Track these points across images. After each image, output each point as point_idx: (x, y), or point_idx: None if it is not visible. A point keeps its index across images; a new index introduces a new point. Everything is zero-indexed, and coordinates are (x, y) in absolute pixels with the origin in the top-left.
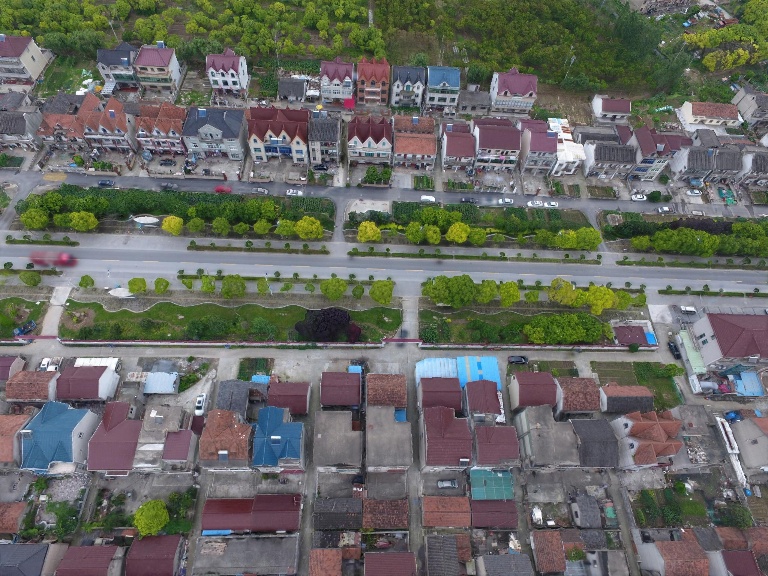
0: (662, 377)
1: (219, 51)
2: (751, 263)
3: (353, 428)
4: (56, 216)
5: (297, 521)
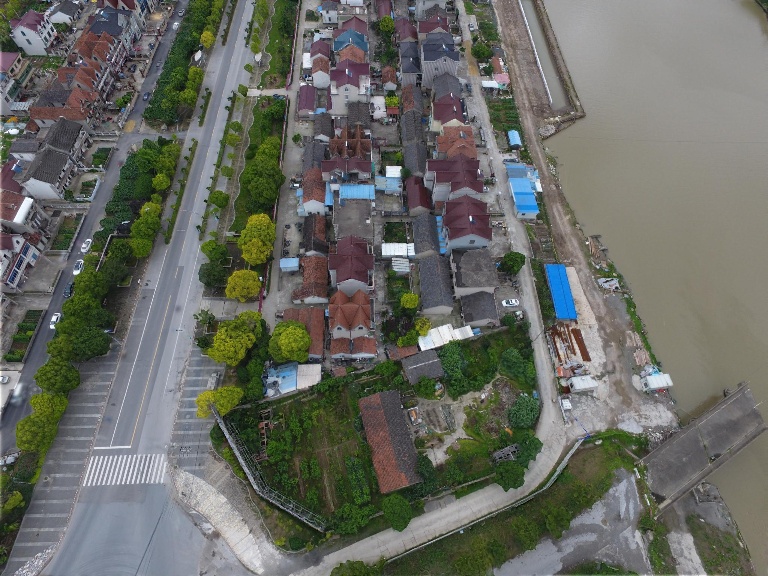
0: None
1: (3, 34)
2: None
3: None
4: (189, 84)
5: None
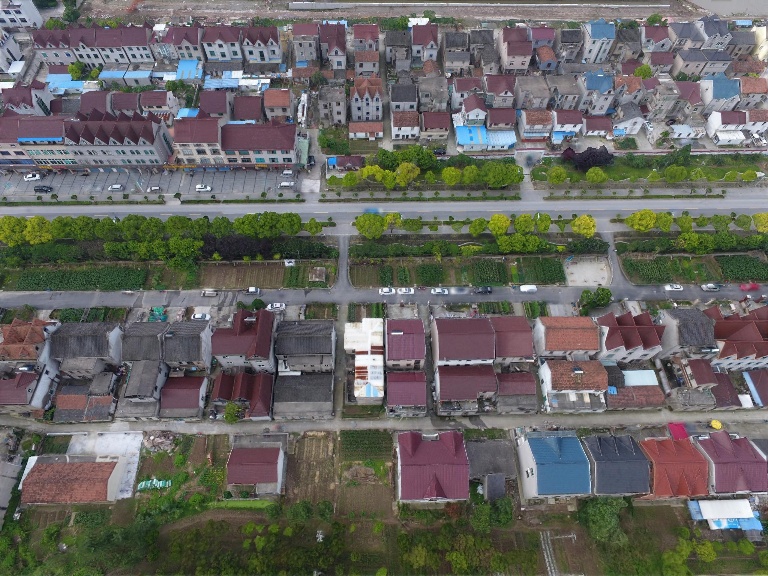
0: None
1: None
2: None
3: (550, 108)
4: None
5: None
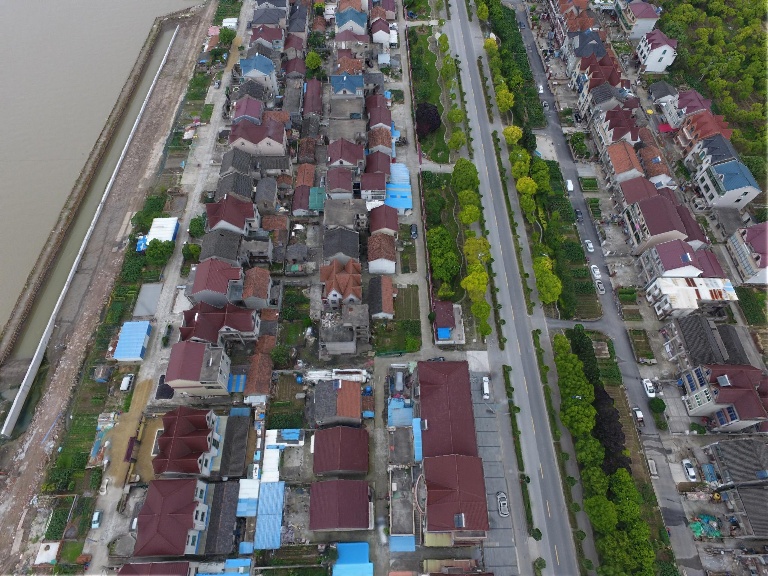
0: None
1: None
2: None
3: None
4: None
5: (307, 113)
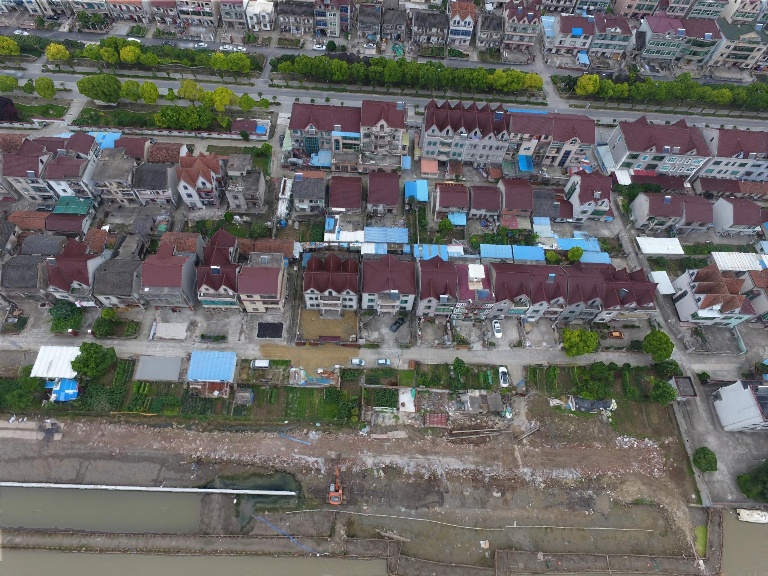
0: (260, 155)
1: None
2: (385, 90)
3: None
4: None
5: None
